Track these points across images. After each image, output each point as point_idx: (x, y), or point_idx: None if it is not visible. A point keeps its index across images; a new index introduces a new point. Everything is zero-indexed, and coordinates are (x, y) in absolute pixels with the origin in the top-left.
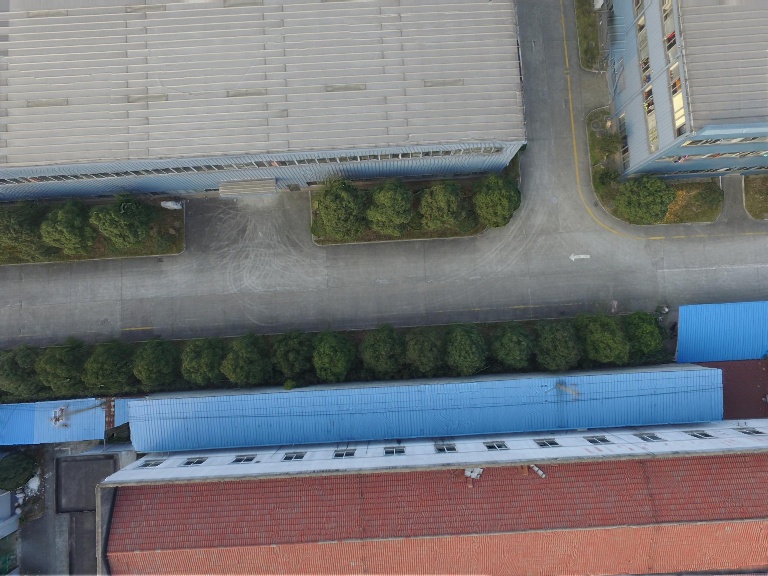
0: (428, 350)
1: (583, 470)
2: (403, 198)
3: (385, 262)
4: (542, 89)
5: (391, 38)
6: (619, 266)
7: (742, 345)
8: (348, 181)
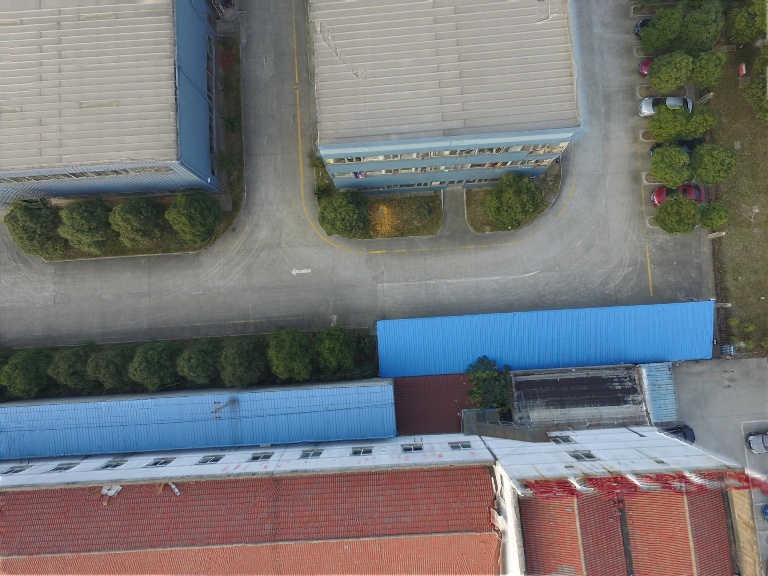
0: (103, 367)
1: (220, 488)
2: (83, 217)
3: (111, 278)
4: (271, 104)
5: (49, 60)
6: (339, 280)
7: (443, 359)
8: (54, 199)
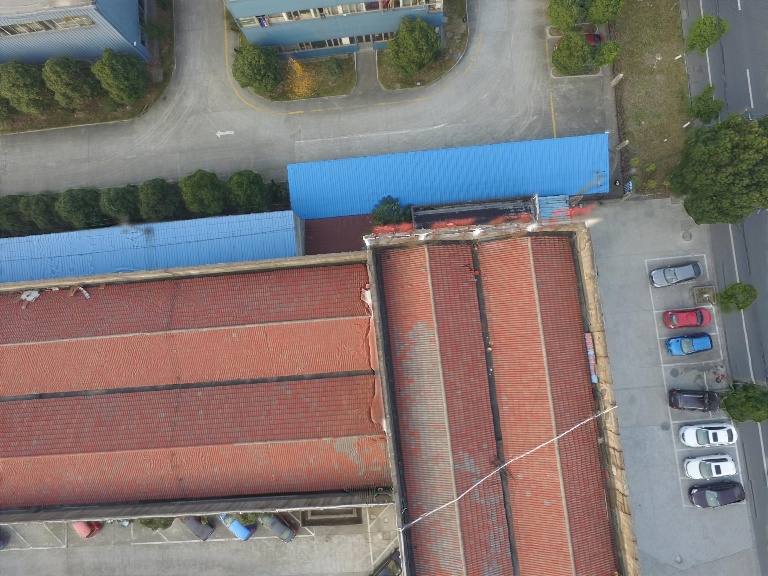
0: (34, 204)
1: None
2: (18, 71)
3: (55, 147)
4: None
5: None
6: (260, 140)
7: (350, 200)
8: None
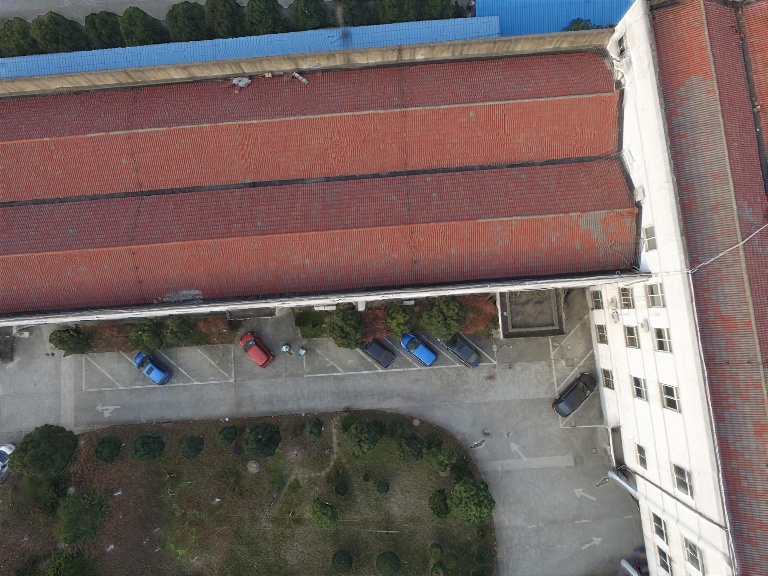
0: (221, 5)
1: None
2: None
3: None
4: None
5: None
6: None
7: (538, 22)
8: None
